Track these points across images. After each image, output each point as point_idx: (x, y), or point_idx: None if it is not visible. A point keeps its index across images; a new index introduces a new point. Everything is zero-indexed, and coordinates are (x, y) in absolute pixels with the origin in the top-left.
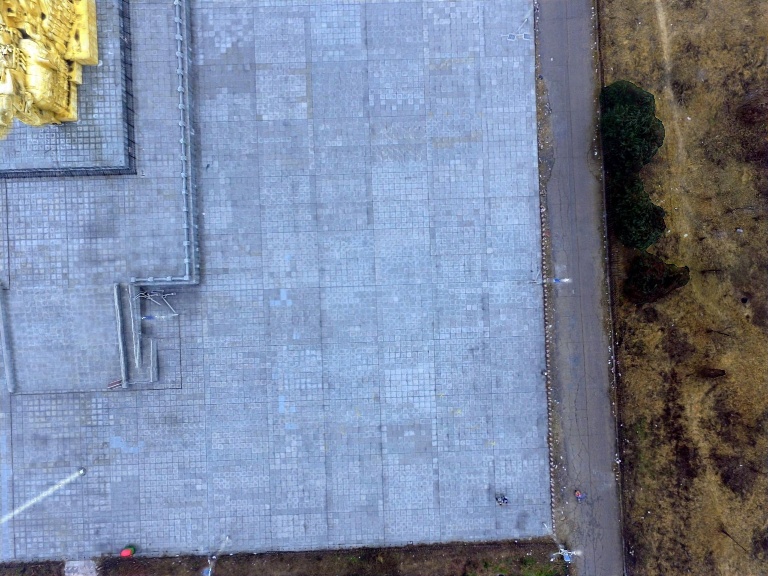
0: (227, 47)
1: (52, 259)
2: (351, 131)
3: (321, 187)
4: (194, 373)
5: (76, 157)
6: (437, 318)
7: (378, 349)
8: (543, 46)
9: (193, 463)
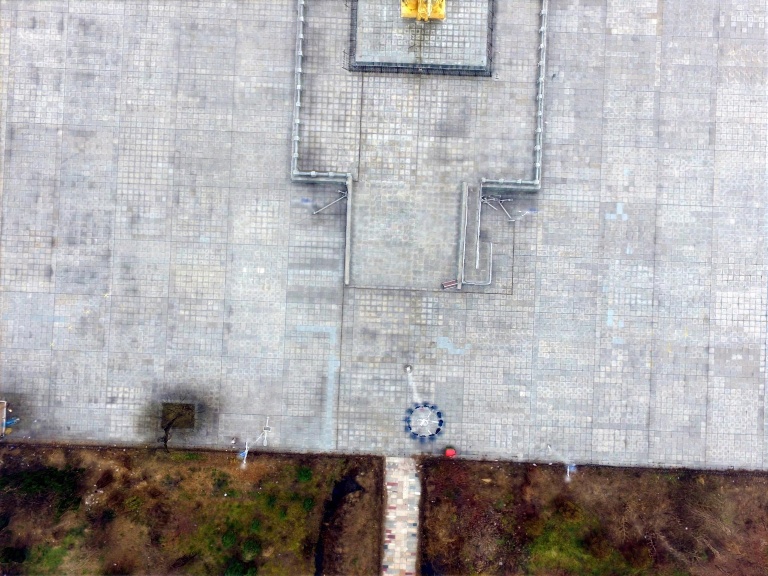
0: None
1: (402, 155)
2: (699, 50)
3: (665, 104)
4: (525, 280)
5: (439, 54)
6: None
7: (711, 270)
8: None
9: (518, 369)
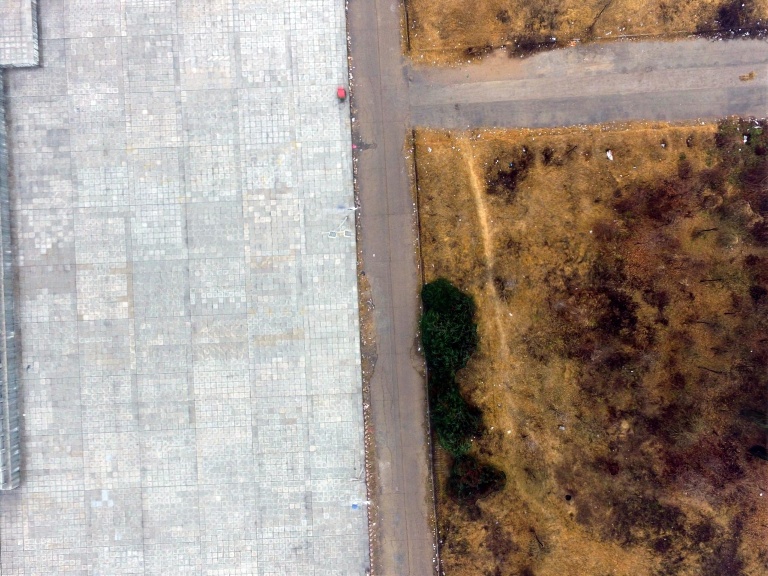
0: (47, 248)
1: None
2: (172, 330)
3: (142, 386)
4: (14, 575)
5: None
6: (260, 517)
7: (200, 549)
8: (365, 242)
9: None
